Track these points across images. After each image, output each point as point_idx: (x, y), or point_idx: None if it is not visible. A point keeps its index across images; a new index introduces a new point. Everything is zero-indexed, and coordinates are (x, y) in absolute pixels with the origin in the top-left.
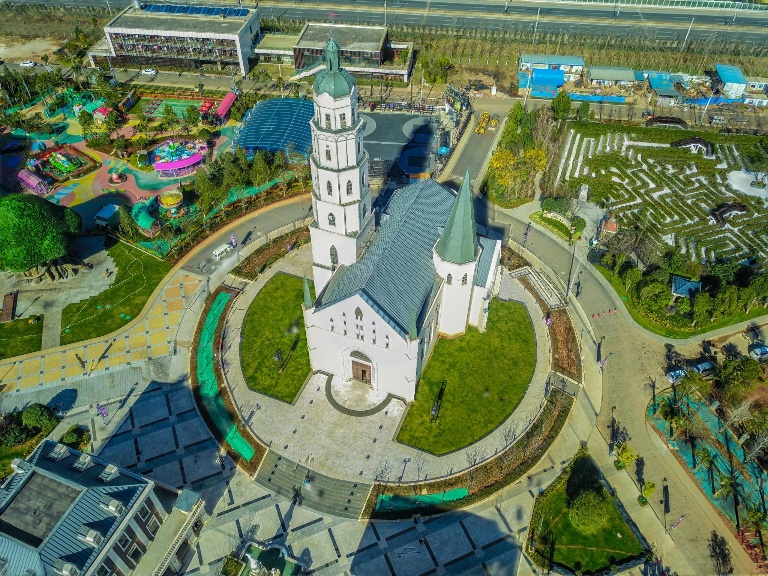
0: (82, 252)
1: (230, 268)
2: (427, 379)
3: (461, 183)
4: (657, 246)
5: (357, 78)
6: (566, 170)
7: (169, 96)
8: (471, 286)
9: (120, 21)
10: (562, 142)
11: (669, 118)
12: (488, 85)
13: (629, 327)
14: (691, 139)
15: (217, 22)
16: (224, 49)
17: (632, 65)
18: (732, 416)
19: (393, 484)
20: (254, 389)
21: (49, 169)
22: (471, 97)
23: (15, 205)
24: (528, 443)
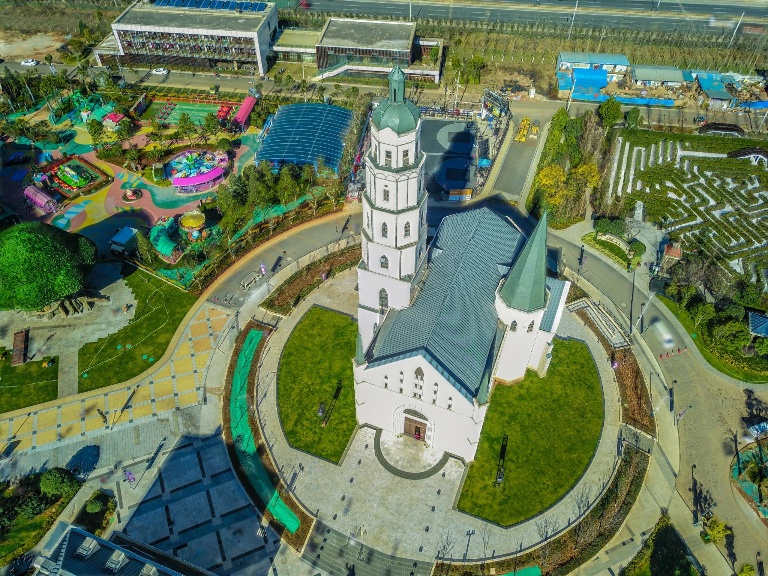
0: (97, 281)
1: (260, 300)
2: (486, 434)
3: (536, 226)
4: (729, 276)
5: (384, 79)
6: (618, 185)
7: (183, 99)
8: (536, 332)
9: (128, 16)
10: (611, 153)
11: (725, 125)
12: (525, 86)
13: (702, 369)
14: (751, 149)
15: (233, 18)
16: (241, 47)
17: (678, 63)
18: None
19: (458, 563)
20: (295, 446)
21: (57, 184)
22: (508, 100)
23: (25, 237)
24: (604, 511)
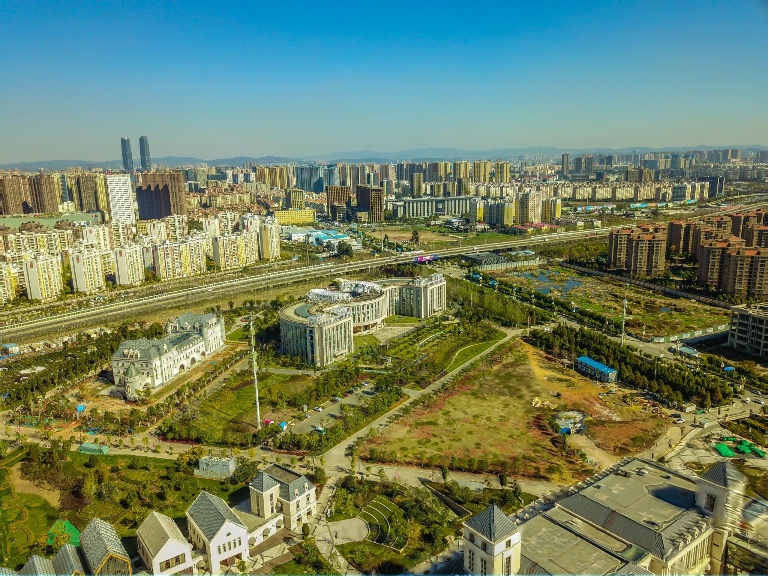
0: None
1: None
2: None
3: None
4: None
5: None
6: None
7: None
8: None
9: None
10: None
11: None
12: None
13: None
14: None
15: None
16: None
17: None
18: (31, 409)
19: None
20: None
21: None
22: None
23: None
24: None
